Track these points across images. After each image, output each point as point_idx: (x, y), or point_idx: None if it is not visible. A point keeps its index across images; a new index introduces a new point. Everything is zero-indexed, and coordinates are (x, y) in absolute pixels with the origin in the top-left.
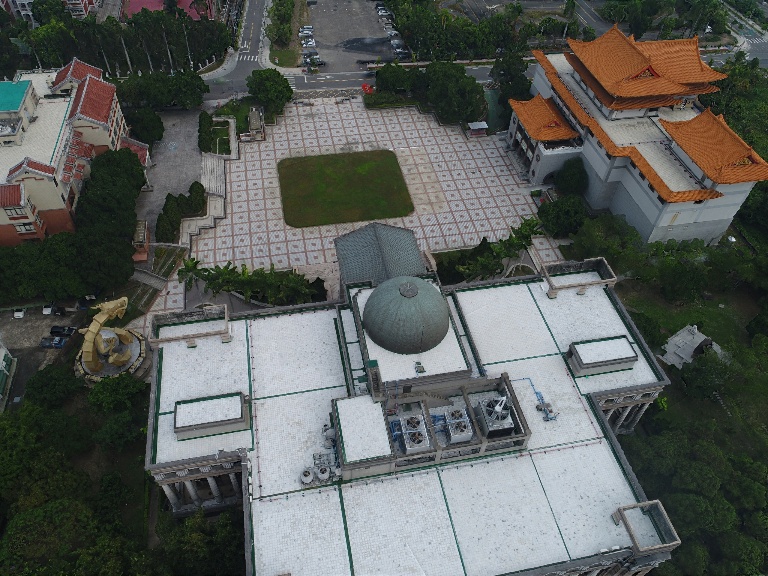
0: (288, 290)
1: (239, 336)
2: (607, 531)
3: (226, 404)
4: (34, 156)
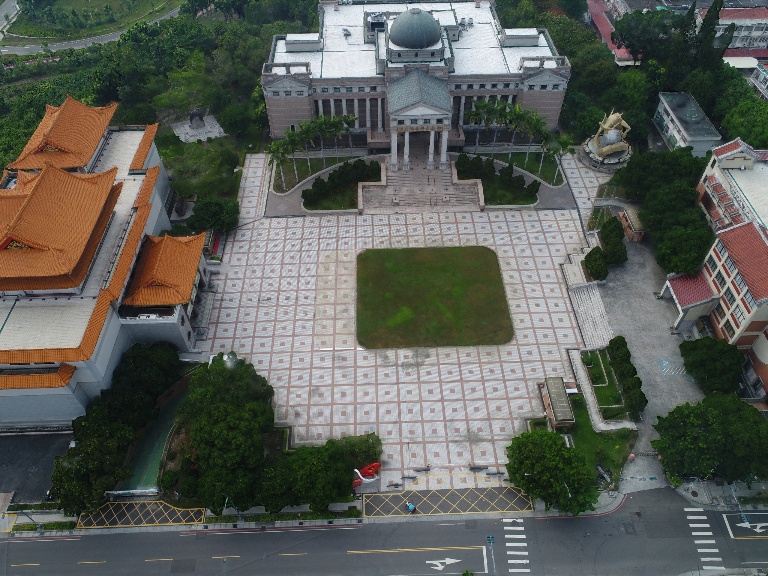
0: None
1: (514, 69)
2: (344, 8)
3: (513, 33)
4: (762, 193)
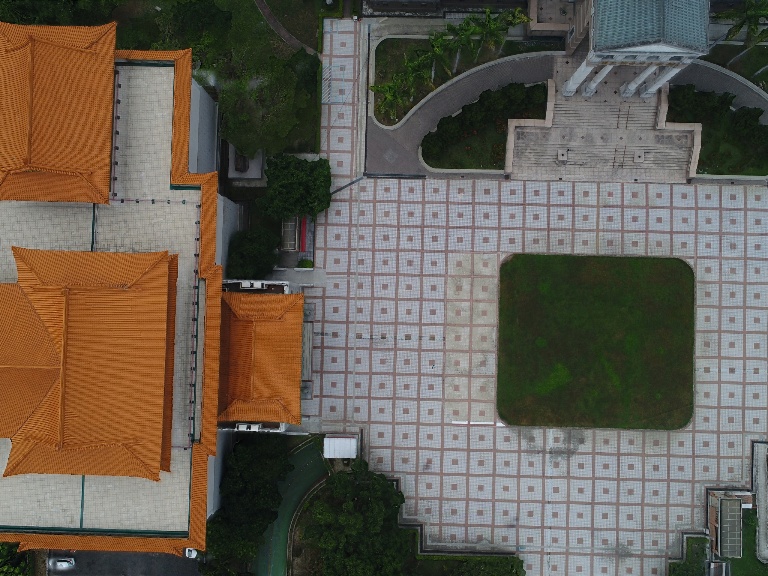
0: (765, 6)
1: None
2: None
3: None
4: None
